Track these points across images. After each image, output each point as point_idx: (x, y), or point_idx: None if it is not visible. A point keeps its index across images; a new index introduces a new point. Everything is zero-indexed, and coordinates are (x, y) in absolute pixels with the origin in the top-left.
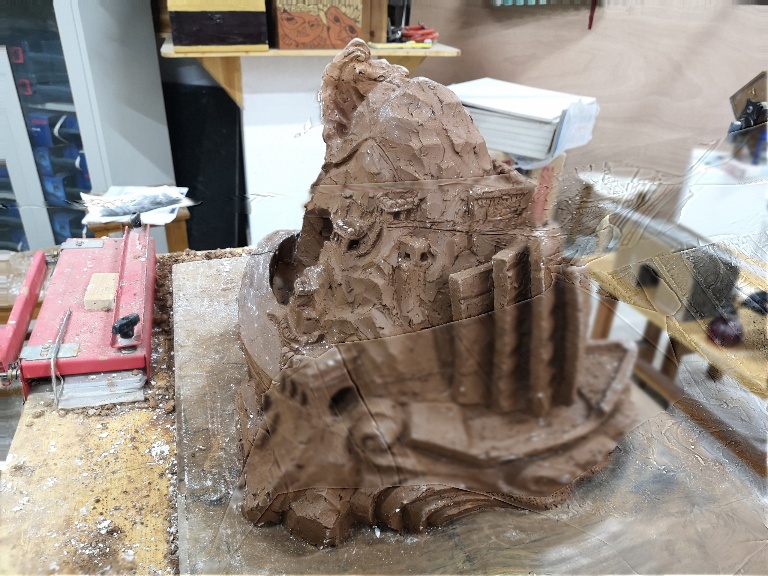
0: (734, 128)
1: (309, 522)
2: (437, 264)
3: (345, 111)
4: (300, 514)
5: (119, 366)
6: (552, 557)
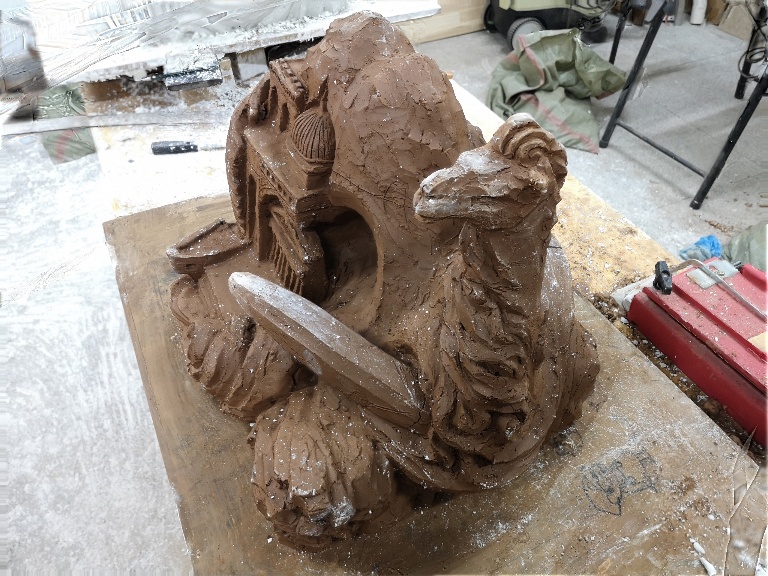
0: None
1: None
2: None
3: None
4: None
5: None
6: None
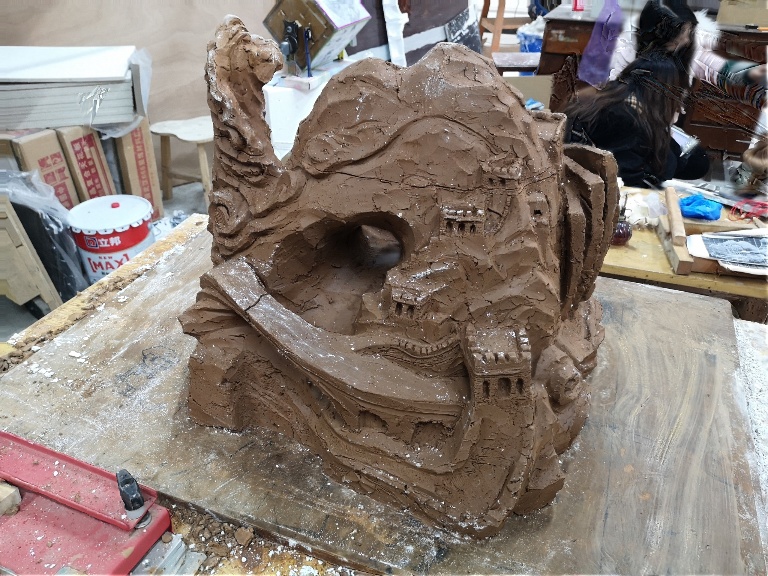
0: (285, 48)
1: (551, 487)
2: (553, 209)
3: (245, 105)
4: (545, 486)
5: (146, 547)
6: (635, 389)
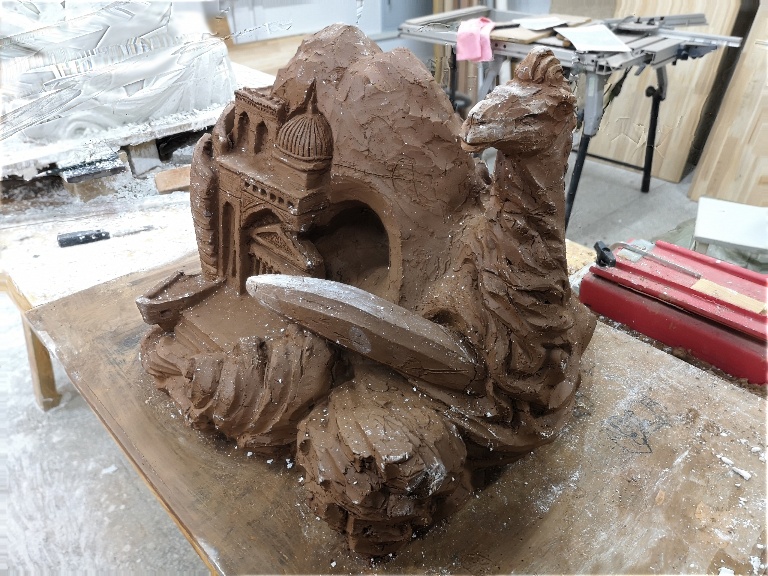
0: None
1: None
2: None
3: None
4: None
5: None
6: None
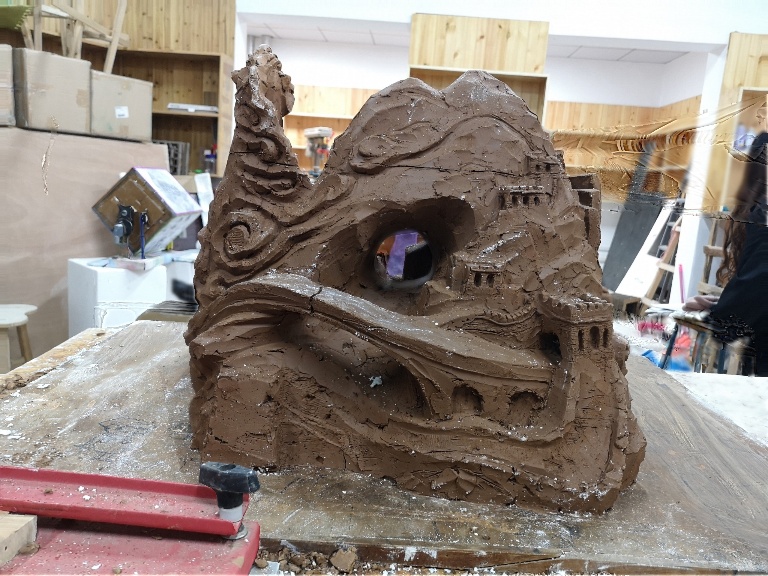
0: (119, 230)
1: (640, 452)
2: None
3: None
4: (638, 449)
5: None
6: None
